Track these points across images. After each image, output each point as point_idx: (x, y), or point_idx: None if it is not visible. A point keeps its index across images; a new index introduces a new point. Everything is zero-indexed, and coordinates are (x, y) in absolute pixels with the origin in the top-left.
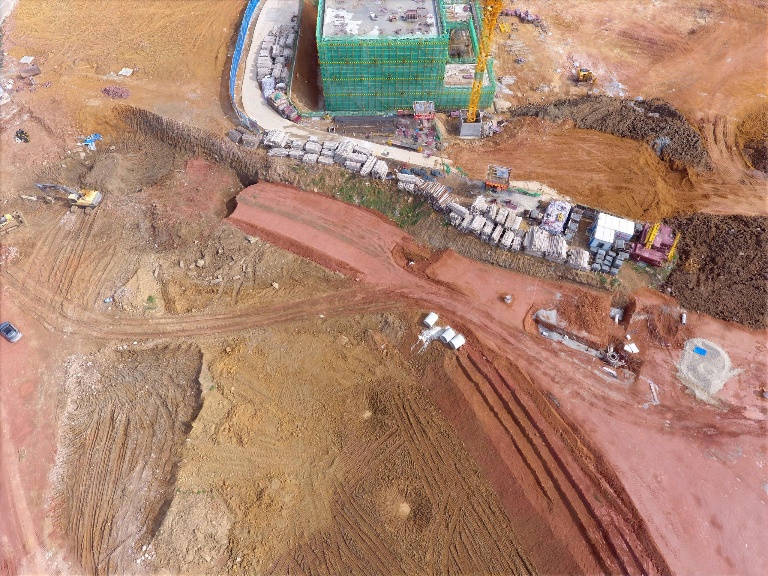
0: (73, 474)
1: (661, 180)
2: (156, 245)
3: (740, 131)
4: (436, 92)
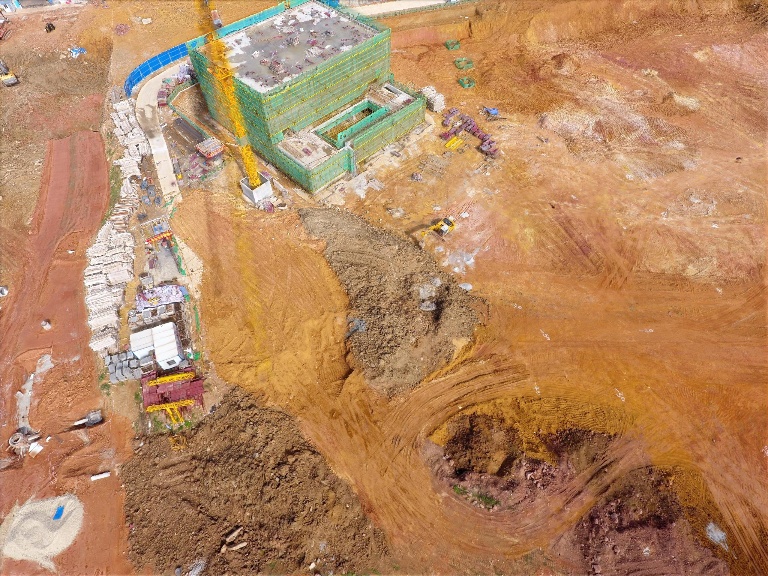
0: None
1: (311, 358)
2: (4, 129)
3: (518, 403)
4: (270, 147)
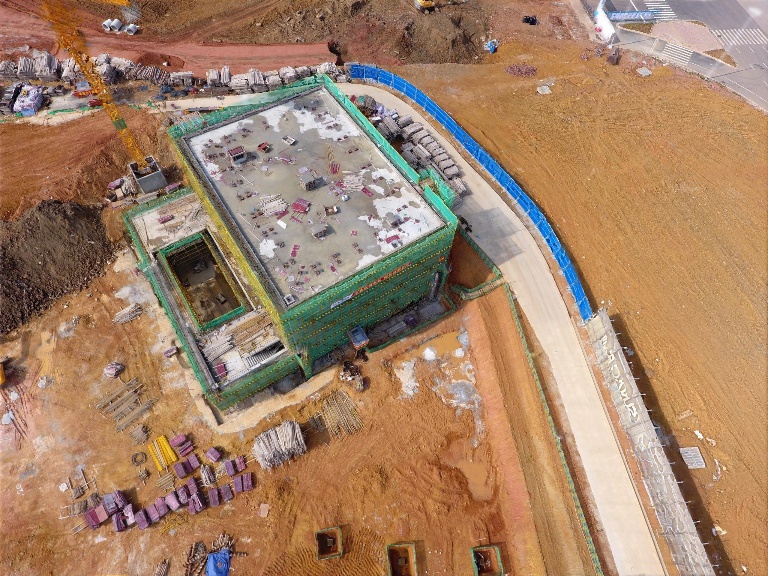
0: None
1: None
2: None
3: None
4: None
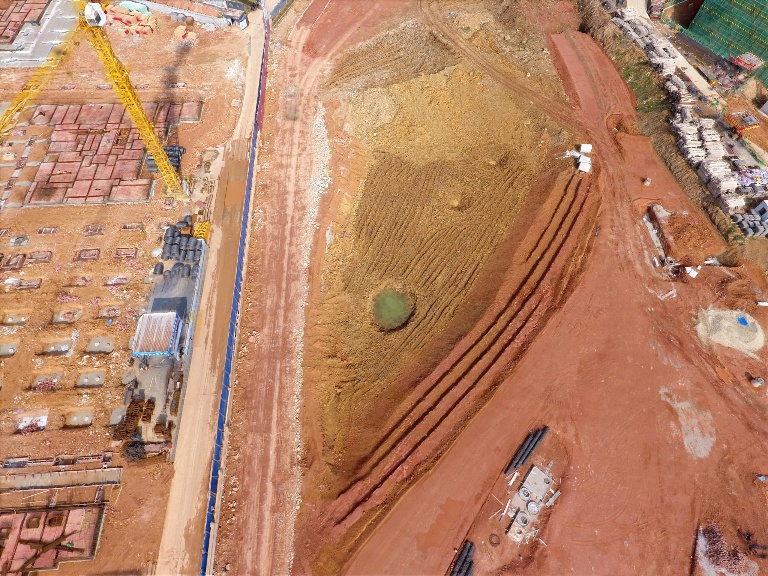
0: (365, 52)
1: None
2: (499, 18)
3: None
4: None
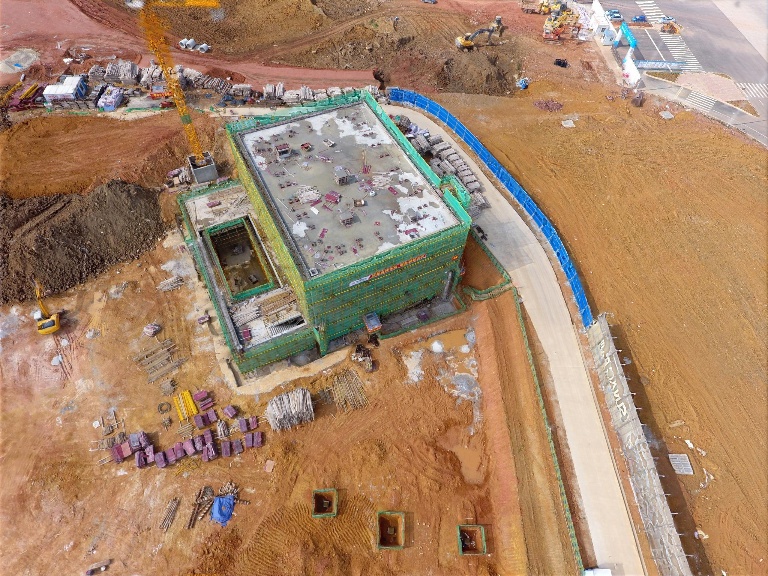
0: None
1: None
2: None
3: None
4: None
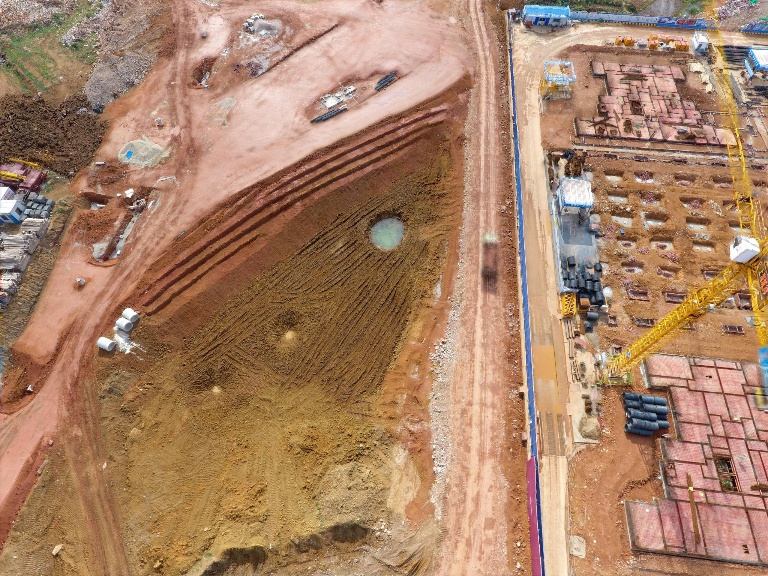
0: None
1: None
2: None
3: None
4: None
